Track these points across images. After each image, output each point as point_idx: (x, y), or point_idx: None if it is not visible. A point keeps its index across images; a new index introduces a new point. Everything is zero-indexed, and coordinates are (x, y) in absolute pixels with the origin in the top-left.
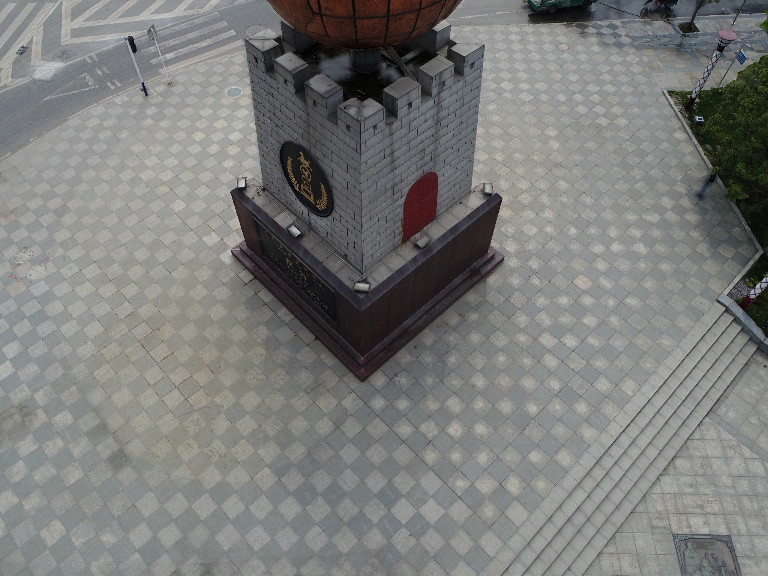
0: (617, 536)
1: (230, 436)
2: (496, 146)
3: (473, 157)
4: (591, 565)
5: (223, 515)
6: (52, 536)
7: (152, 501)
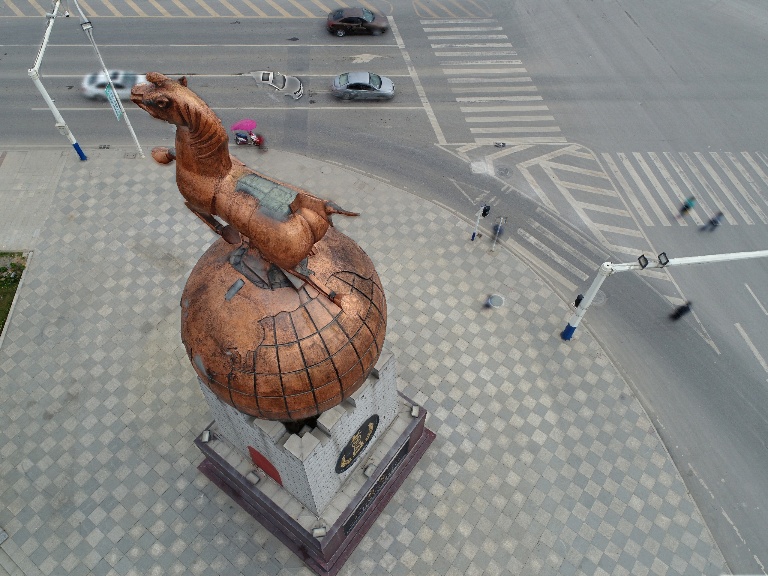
0: None
1: (159, 387)
2: (489, 567)
3: None
4: None
5: (106, 397)
6: (103, 311)
7: (119, 355)
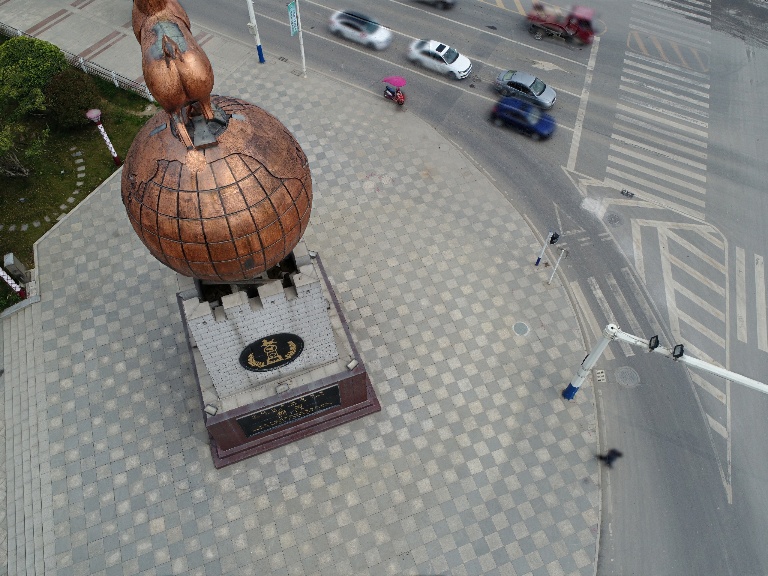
0: (4, 440)
1: None
2: (350, 543)
3: (212, 379)
4: (5, 413)
5: None
6: None
7: None
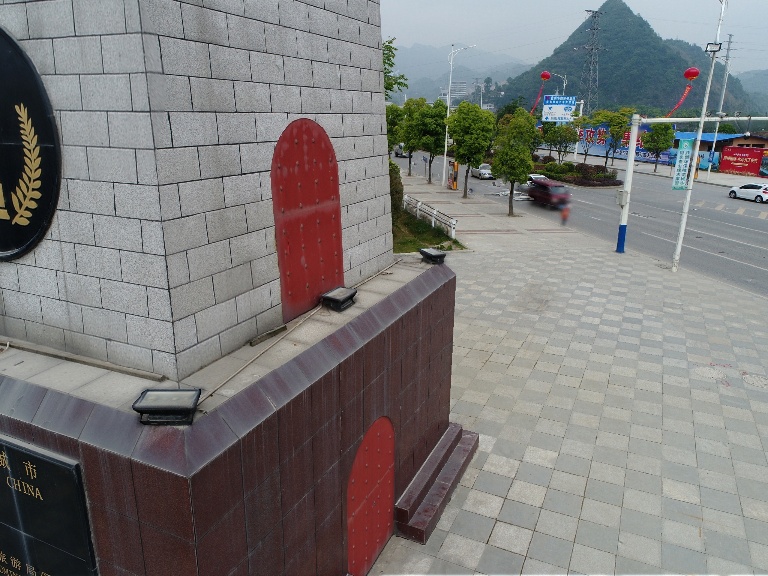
0: None
1: None
2: None
3: None
4: None
5: None
6: None
7: None
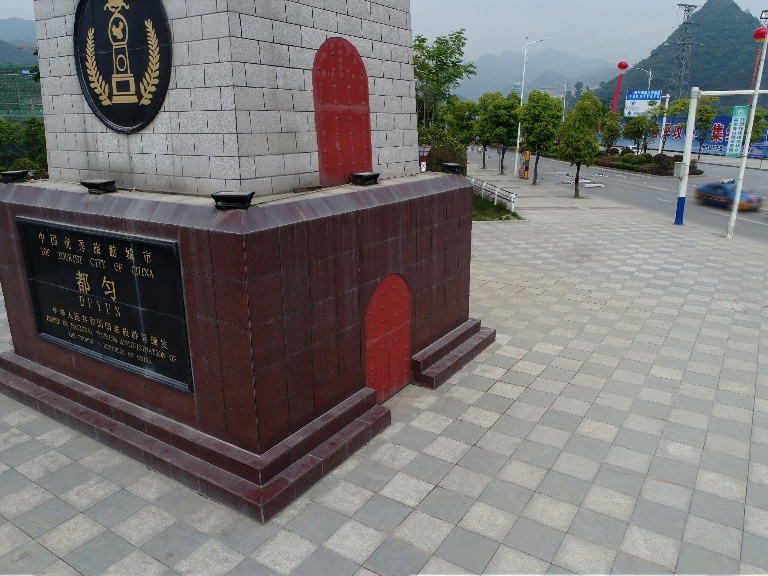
0: None
1: None
2: None
3: None
4: None
5: None
6: None
7: None
